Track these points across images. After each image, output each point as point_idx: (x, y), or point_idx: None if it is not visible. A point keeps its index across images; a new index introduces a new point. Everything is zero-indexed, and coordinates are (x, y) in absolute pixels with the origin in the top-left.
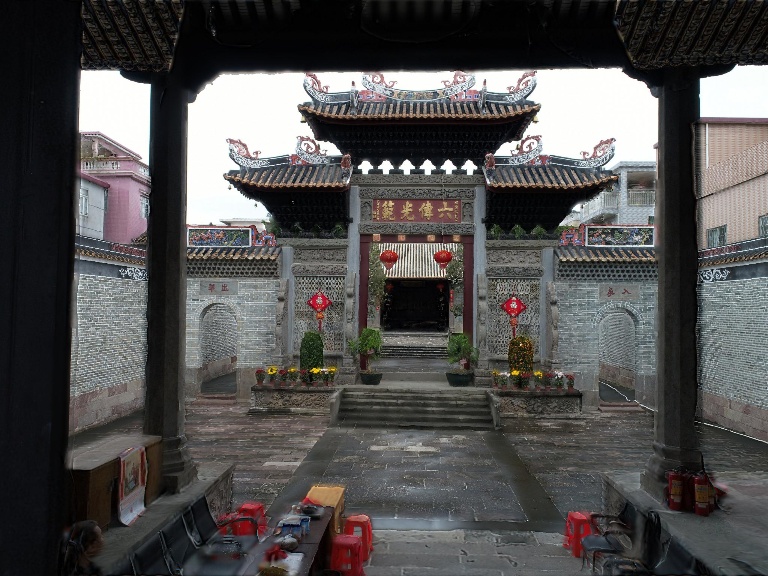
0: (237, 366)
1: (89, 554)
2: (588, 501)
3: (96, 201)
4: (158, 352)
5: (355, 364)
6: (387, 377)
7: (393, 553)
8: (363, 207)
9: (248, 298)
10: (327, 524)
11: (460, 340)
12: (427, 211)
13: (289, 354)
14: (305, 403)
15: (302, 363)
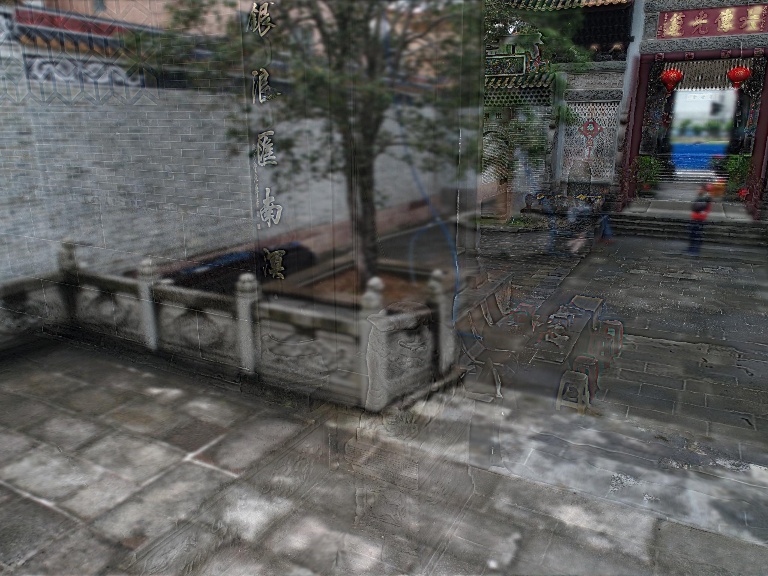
0: (508, 190)
1: None
2: None
3: None
4: (462, 186)
5: (623, 191)
6: (656, 205)
7: (640, 352)
8: (647, 23)
9: (520, 126)
10: (587, 321)
11: (745, 169)
12: (725, 21)
13: (557, 180)
14: (570, 226)
15: (569, 189)
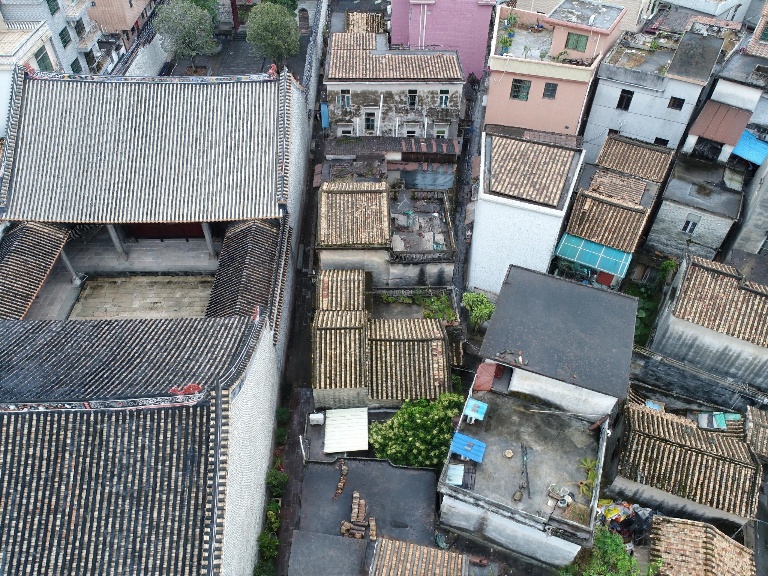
0: None
1: None
2: None
3: None
4: None
5: None
6: None
7: None
8: None
9: None
10: None
11: None
12: None
13: None
14: None
15: None
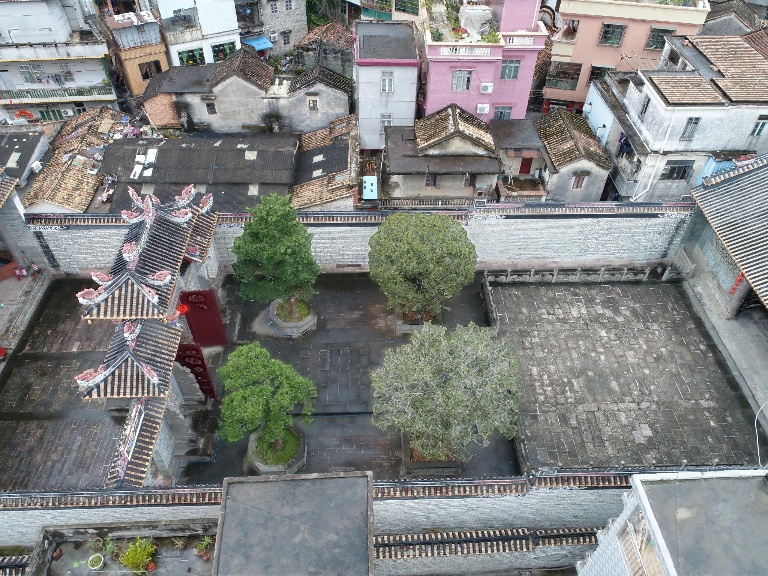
0: None
1: None
2: (1, 431)
3: (405, 78)
4: None
5: (184, 339)
6: None
7: None
8: None
9: None
10: None
11: None
12: None
13: None
14: None
15: None
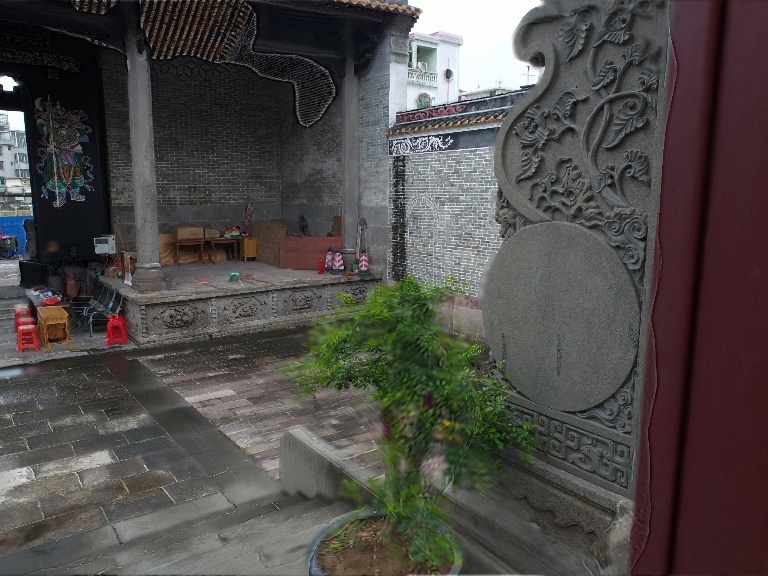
0: None
1: (117, 279)
2: None
3: None
4: None
5: (542, 531)
6: None
7: (1, 354)
8: None
9: None
10: None
11: None
12: None
13: None
14: None
15: None
